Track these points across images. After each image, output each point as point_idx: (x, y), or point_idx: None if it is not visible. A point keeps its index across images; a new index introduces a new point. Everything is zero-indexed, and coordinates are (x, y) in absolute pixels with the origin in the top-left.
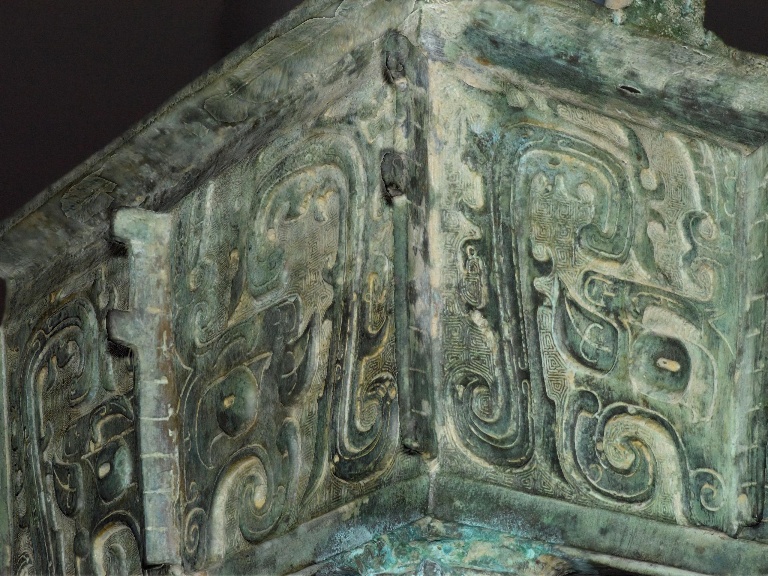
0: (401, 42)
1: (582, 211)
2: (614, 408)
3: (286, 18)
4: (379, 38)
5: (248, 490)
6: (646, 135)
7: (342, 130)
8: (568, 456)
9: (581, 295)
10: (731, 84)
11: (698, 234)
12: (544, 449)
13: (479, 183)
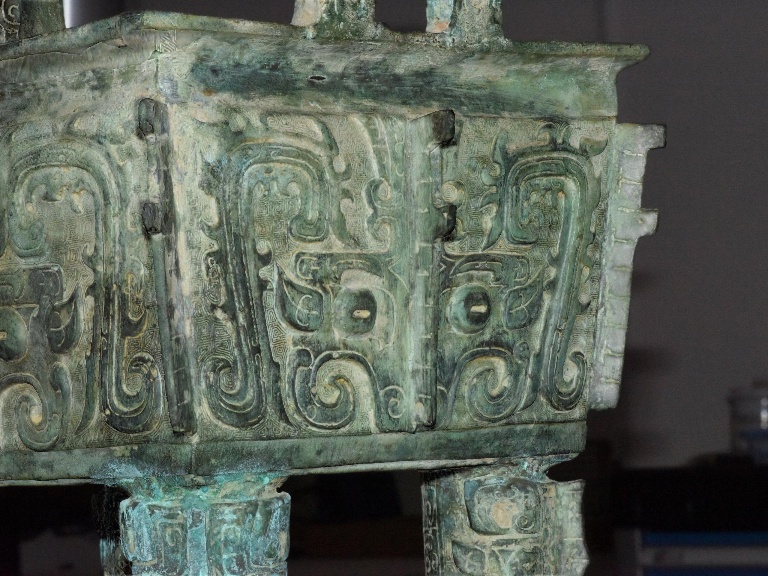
0: (147, 101)
1: (291, 205)
2: (323, 357)
3: (35, 41)
4: (119, 69)
5: (24, 407)
6: (334, 123)
7: (93, 146)
8: (291, 403)
9: (294, 274)
10: (395, 57)
11: (378, 198)
12: (274, 404)
13: (214, 203)
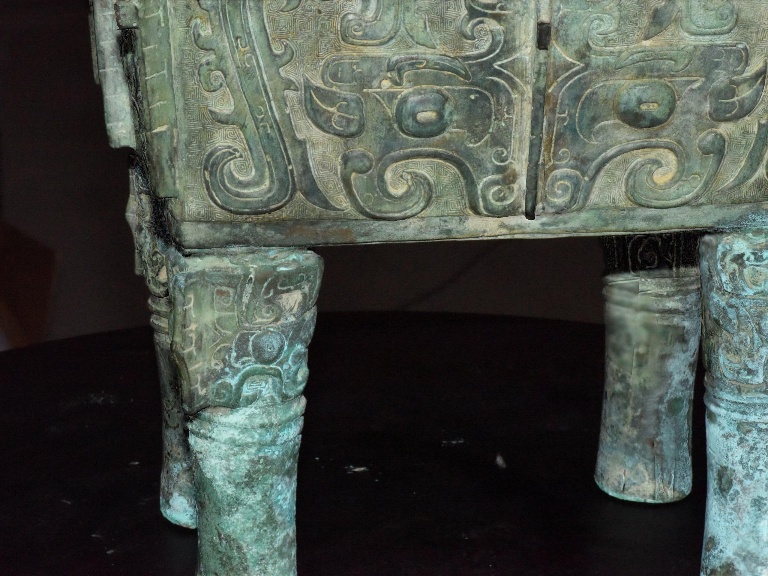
0: None
1: None
2: None
3: None
4: None
5: (646, 169)
6: None
7: None
8: None
9: None
10: None
11: None
12: None
13: None
